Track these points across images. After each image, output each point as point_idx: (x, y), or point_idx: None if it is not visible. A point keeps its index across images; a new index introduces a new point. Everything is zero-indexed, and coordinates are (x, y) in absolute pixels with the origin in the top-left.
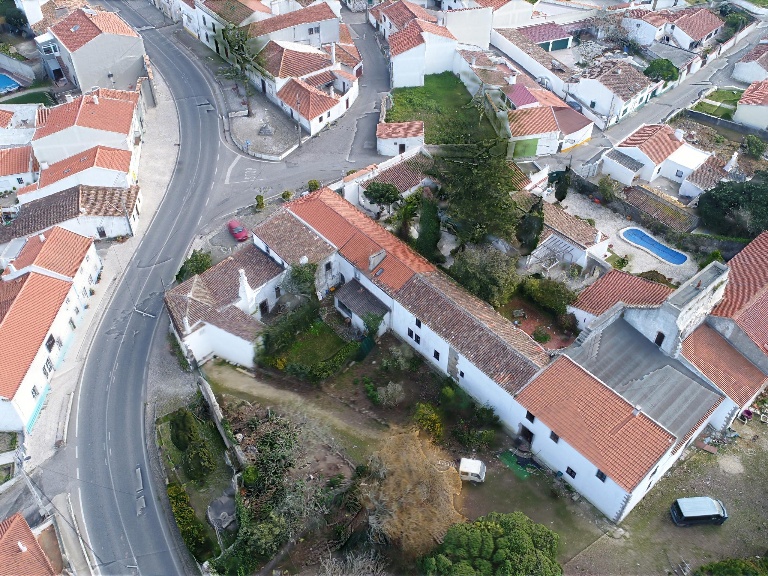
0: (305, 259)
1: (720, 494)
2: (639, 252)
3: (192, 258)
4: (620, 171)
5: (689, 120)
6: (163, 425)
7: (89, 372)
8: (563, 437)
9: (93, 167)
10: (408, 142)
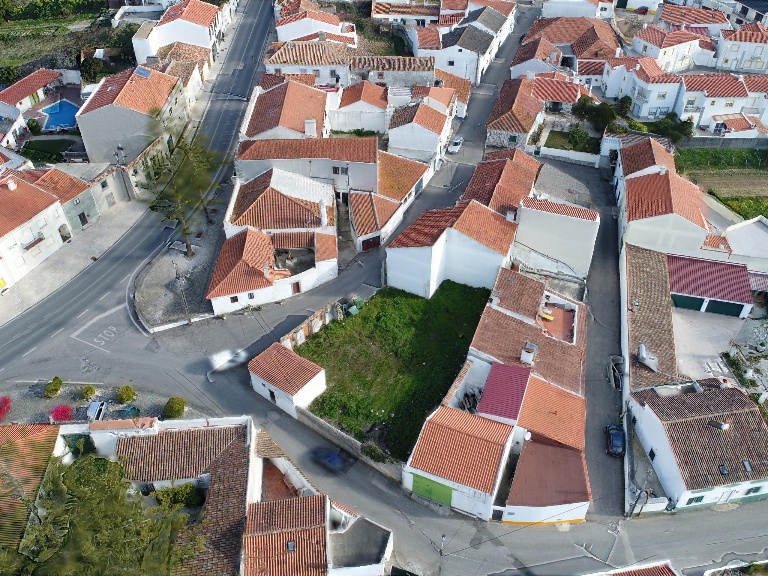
0: None
1: None
2: None
3: None
4: None
5: None
6: None
7: None
8: None
9: None
10: (277, 392)
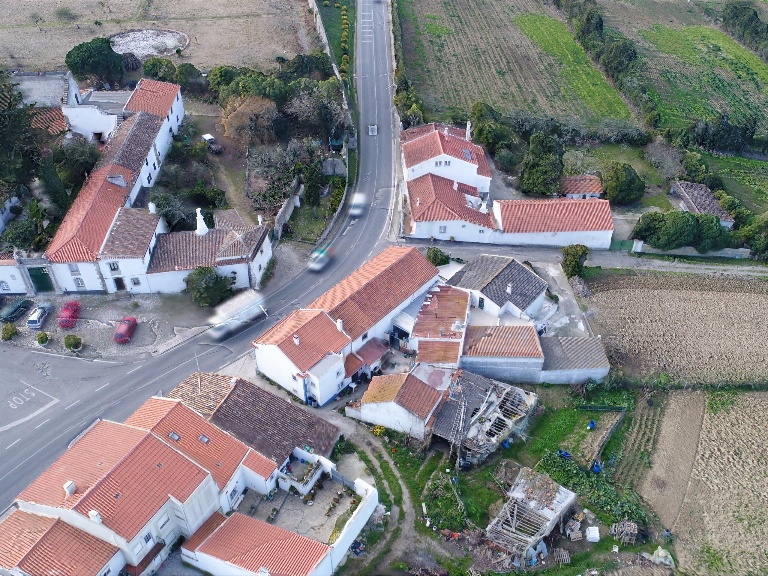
0: None
1: None
2: None
3: None
4: None
5: None
6: None
7: None
8: (172, 103)
9: None
10: None
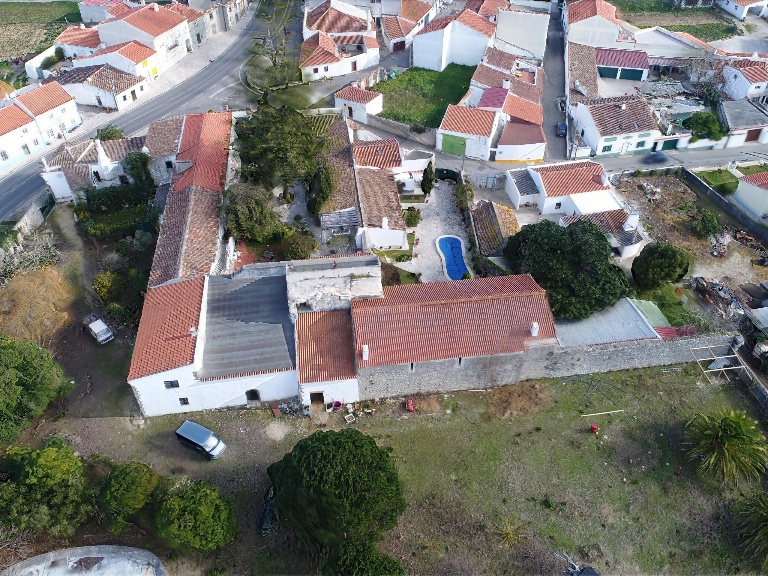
0: (145, 149)
1: (239, 442)
2: (435, 257)
3: (104, 128)
4: (513, 191)
5: (680, 180)
6: (3, 226)
7: (6, 180)
8: (140, 327)
9: (115, 52)
10: (354, 106)
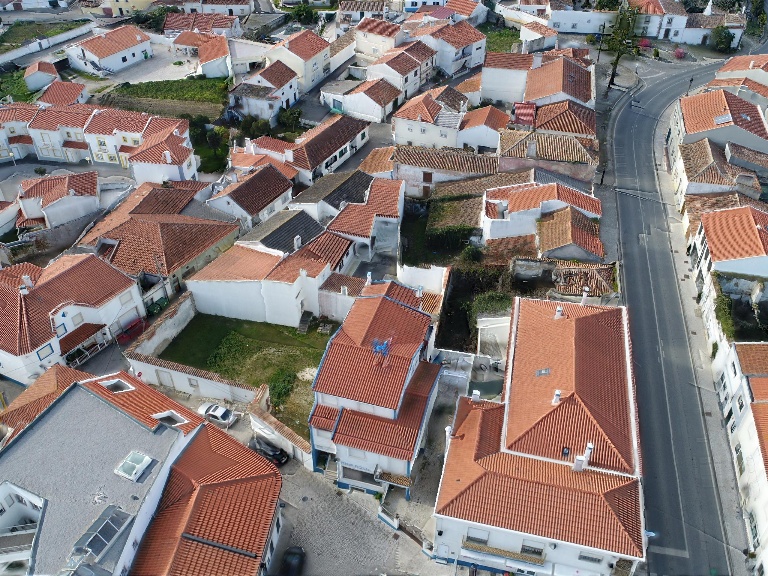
0: None
1: None
2: None
3: None
4: None
5: None
6: None
7: None
8: None
9: None
10: None
